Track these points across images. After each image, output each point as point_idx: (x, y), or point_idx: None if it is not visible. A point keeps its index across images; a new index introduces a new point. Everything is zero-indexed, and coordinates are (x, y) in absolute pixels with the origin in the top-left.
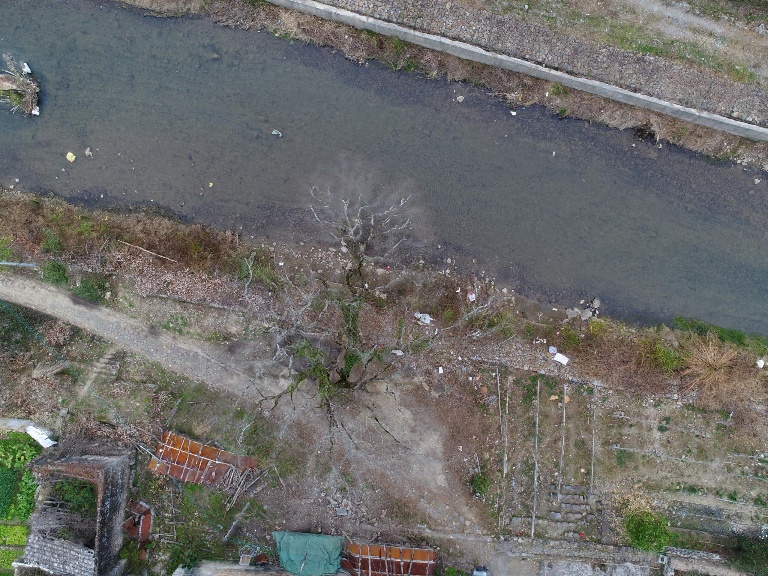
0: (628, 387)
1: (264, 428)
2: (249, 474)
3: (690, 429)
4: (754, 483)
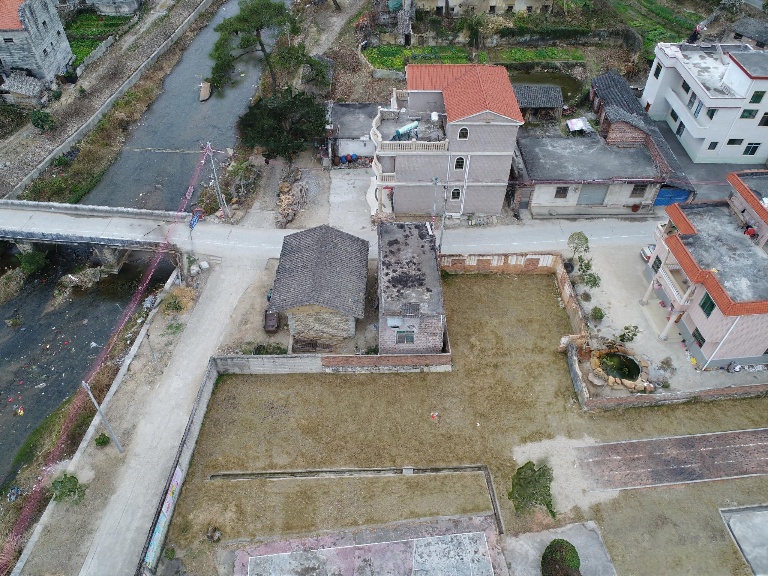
0: None
1: None
2: None
3: None
4: None
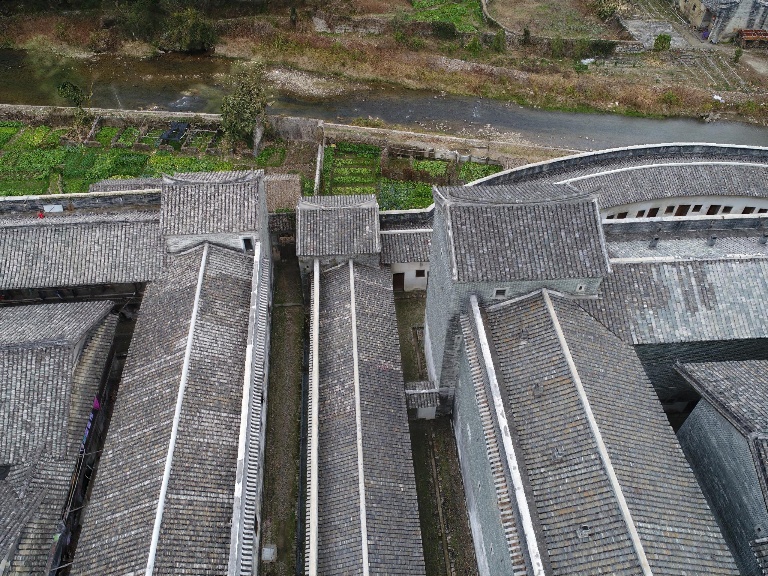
0: None
1: None
2: None
3: None
4: None
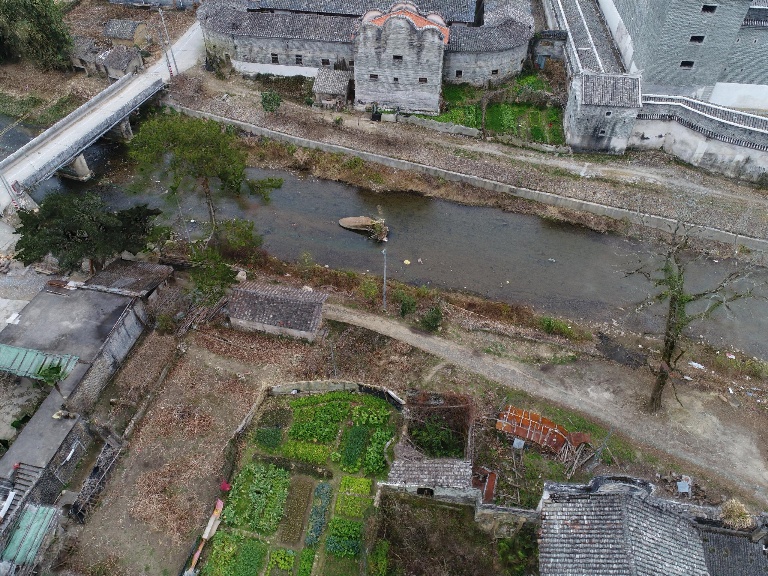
0: None
1: (586, 422)
2: (582, 452)
3: None
4: None
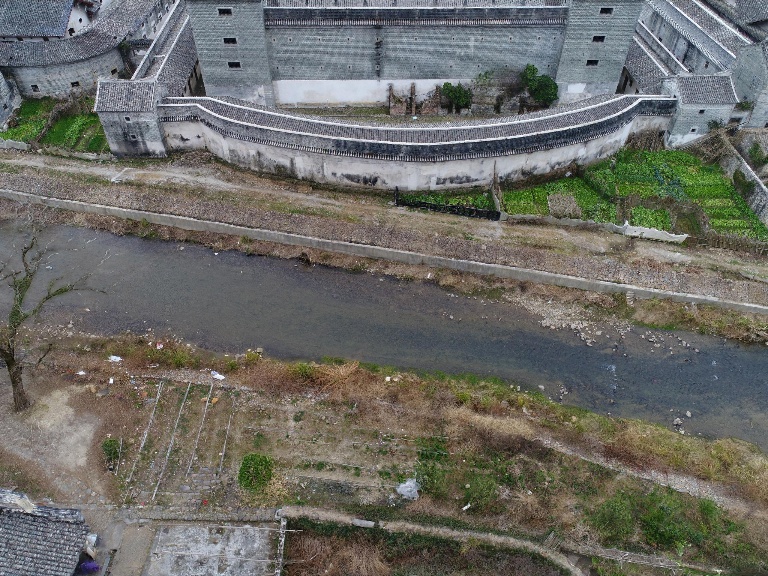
0: (269, 389)
1: None
2: None
3: (321, 418)
4: (379, 458)
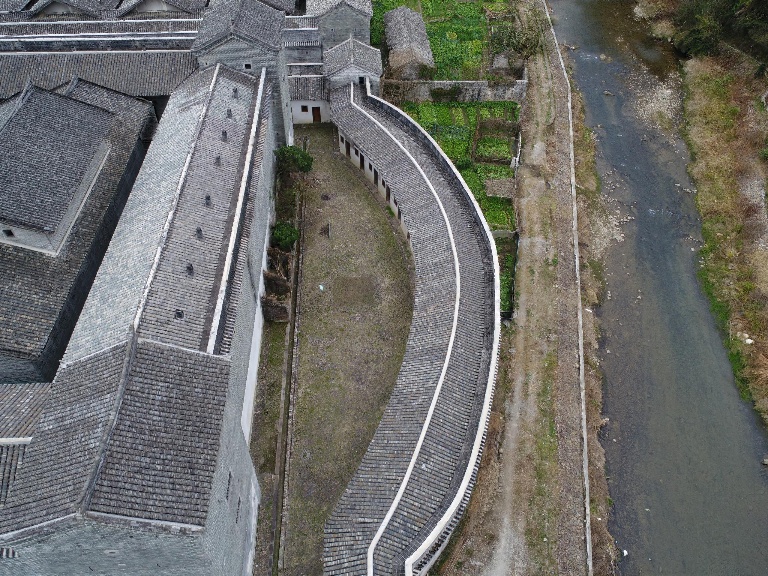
0: None
1: None
2: None
3: None
4: None
